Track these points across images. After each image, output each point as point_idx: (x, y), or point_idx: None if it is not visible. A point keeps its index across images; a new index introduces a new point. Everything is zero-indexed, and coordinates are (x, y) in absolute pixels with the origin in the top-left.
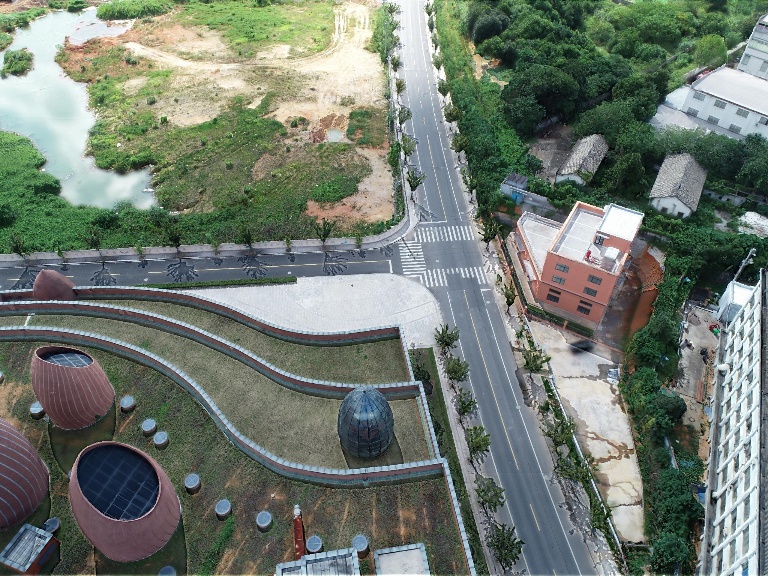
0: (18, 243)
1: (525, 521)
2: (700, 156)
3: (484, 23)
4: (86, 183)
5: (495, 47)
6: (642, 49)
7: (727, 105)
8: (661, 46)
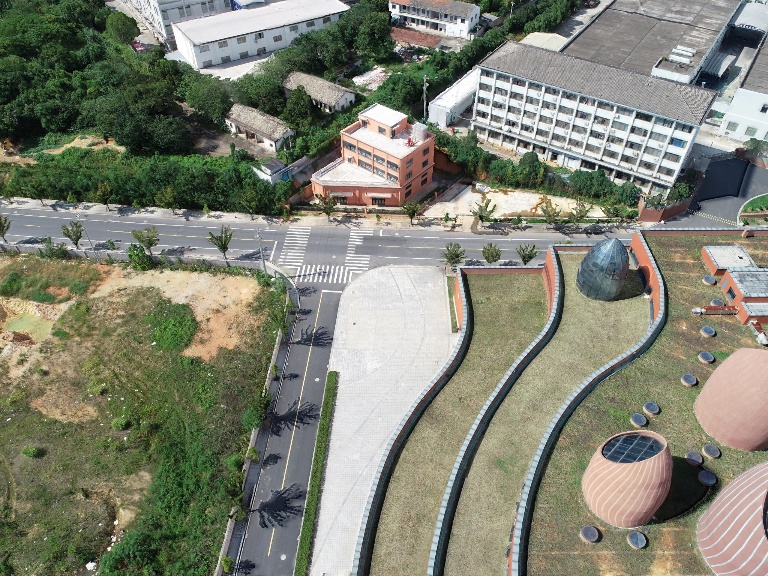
0: None
1: None
2: (301, 68)
3: None
4: None
5: (6, 126)
6: (85, 54)
7: (228, 42)
8: (73, 50)
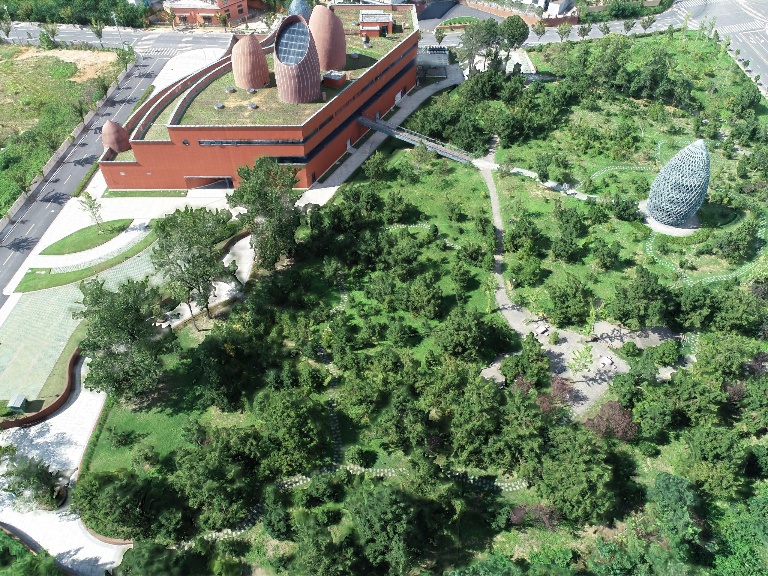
0: (22, 178)
1: None
2: None
3: None
4: None
5: None
6: None
7: None
8: None
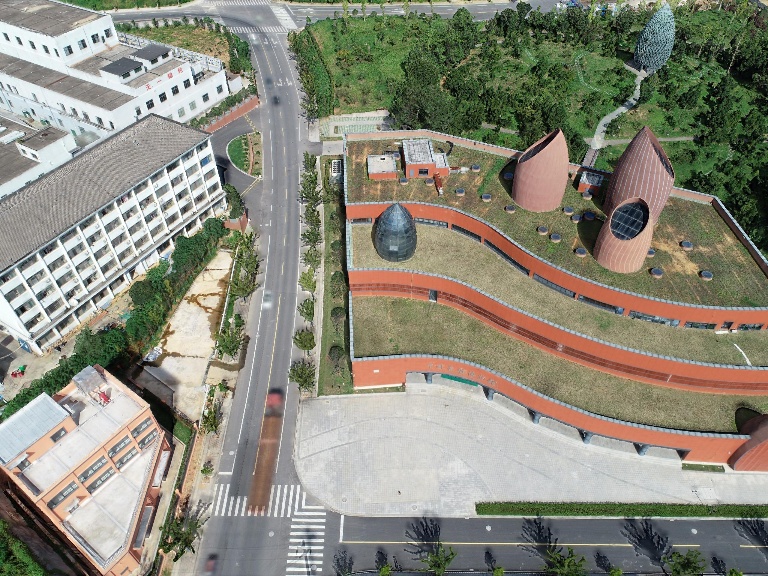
0: None
1: (290, 267)
2: None
3: None
4: None
5: None
6: None
7: None
8: None
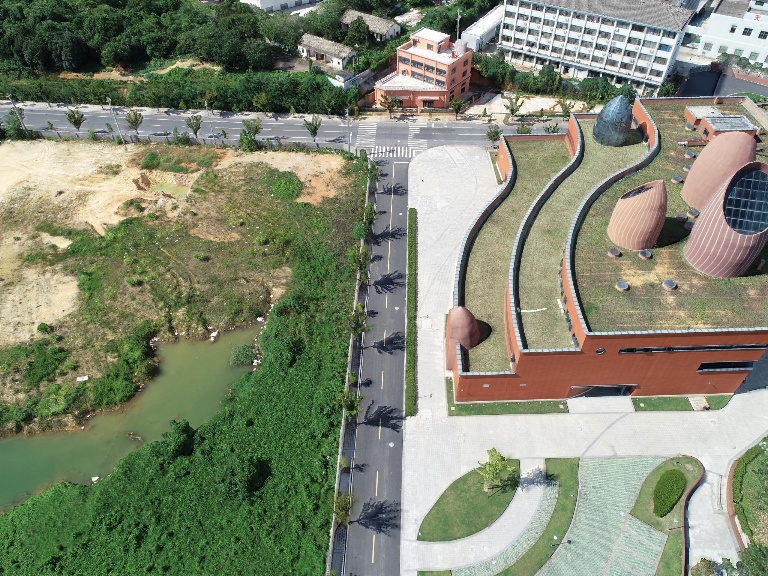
0: None
1: None
2: (354, 7)
3: (70, 45)
4: (160, 413)
5: (122, 50)
6: (165, 3)
7: None
8: None
